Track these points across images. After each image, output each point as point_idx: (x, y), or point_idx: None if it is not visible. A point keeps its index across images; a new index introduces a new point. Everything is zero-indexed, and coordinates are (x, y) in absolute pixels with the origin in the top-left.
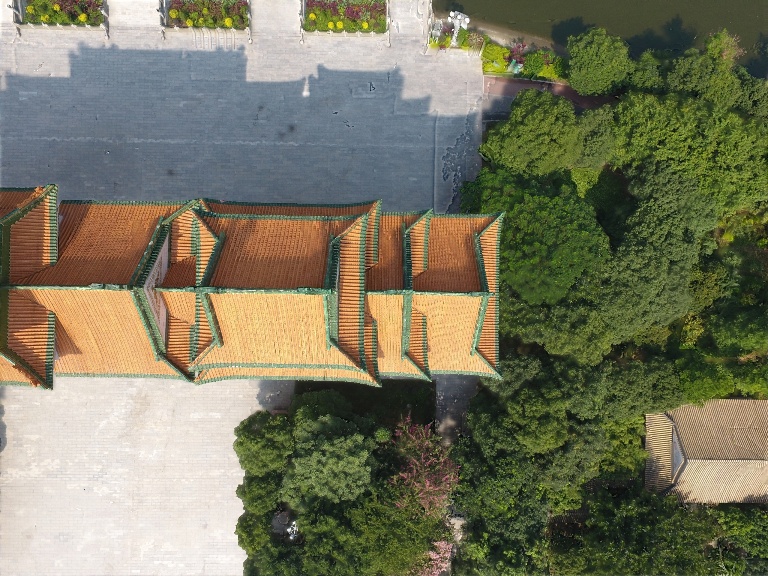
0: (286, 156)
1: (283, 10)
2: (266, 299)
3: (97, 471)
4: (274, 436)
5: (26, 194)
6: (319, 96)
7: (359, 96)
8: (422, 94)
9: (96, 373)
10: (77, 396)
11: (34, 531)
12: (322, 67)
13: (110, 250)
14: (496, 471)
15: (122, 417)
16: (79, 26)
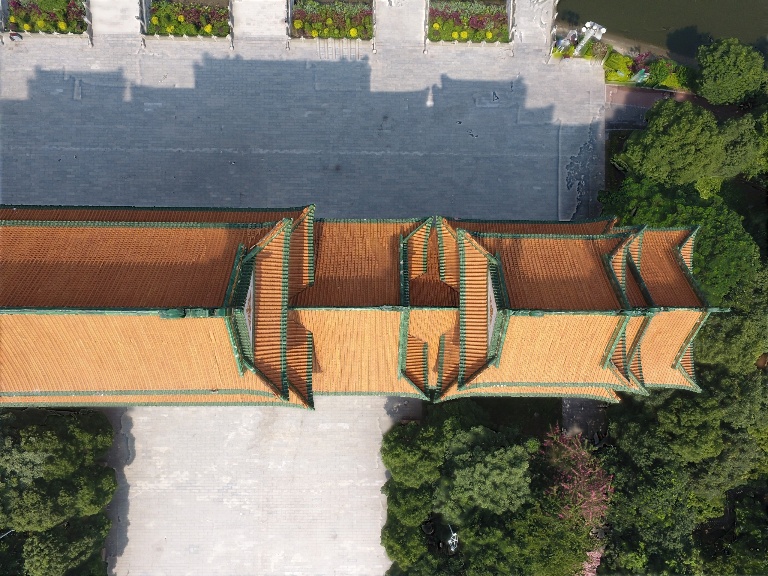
0: (411, 166)
1: (407, 20)
2: (560, 320)
3: (226, 483)
4: (430, 448)
5: (285, 214)
6: (443, 106)
7: (483, 106)
8: (545, 103)
9: (331, 391)
10: (205, 408)
11: (164, 543)
12: (446, 77)
13: (359, 269)
14: (654, 481)
15: (251, 428)
16: (205, 37)
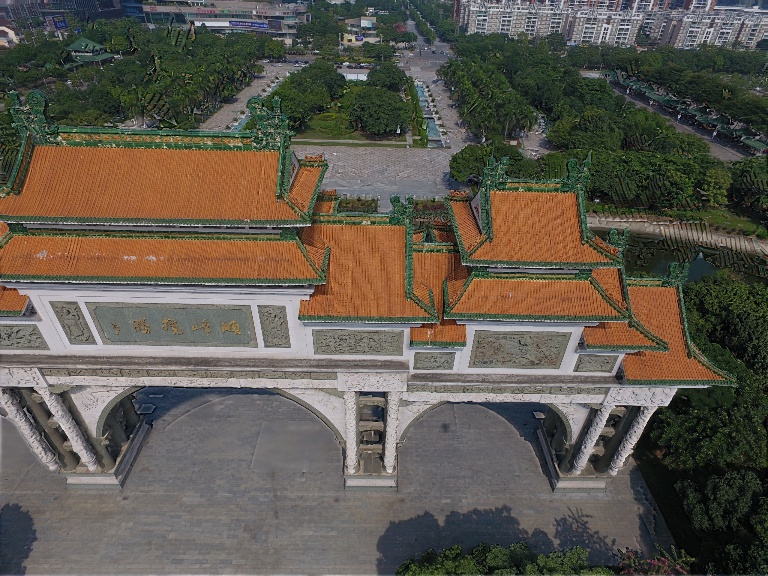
0: None
1: None
2: (531, 198)
3: None
4: (457, 566)
5: None
6: None
7: None
8: None
9: (340, 315)
10: None
11: None
12: None
13: None
14: None
15: None
16: None
